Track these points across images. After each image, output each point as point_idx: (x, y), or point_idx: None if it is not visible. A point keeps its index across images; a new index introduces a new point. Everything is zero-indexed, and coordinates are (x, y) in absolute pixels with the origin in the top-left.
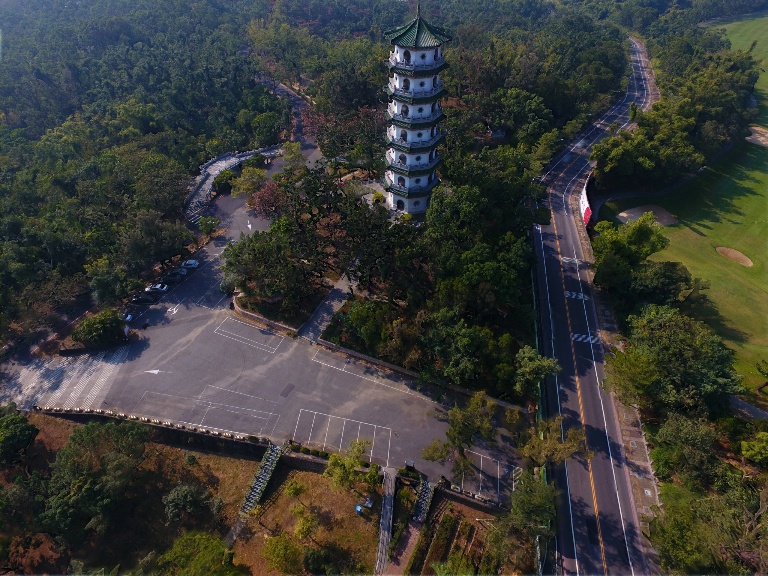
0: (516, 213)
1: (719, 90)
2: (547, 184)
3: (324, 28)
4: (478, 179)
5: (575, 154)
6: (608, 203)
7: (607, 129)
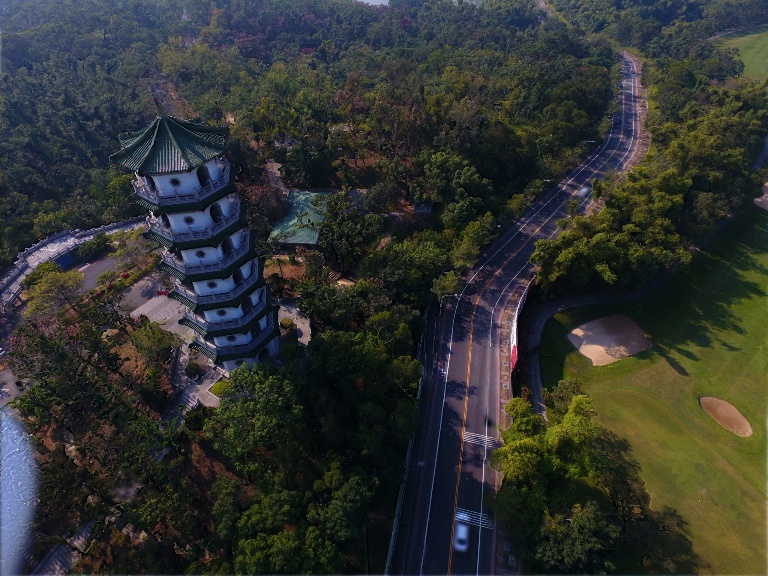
0: (360, 415)
1: (721, 144)
2: (475, 289)
3: (272, 42)
4: (344, 317)
5: (524, 236)
6: (558, 315)
7: (574, 193)
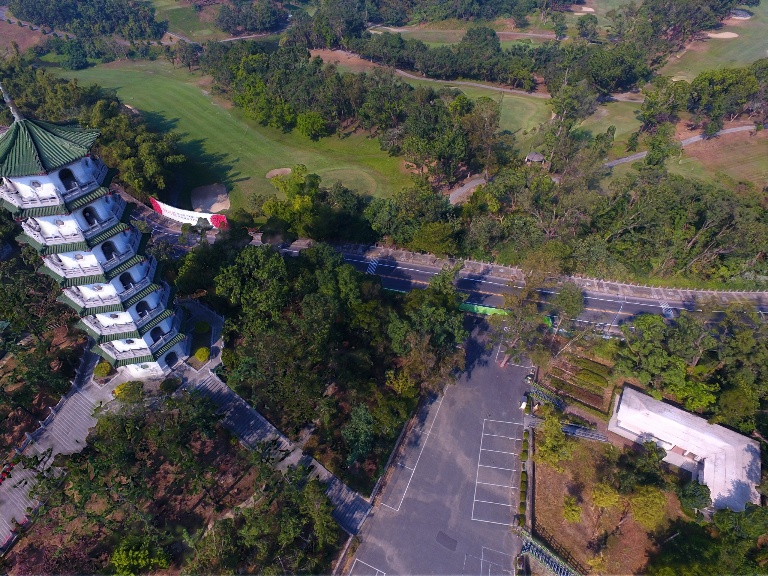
0: None
1: None
2: None
3: None
4: None
5: None
6: None
7: None
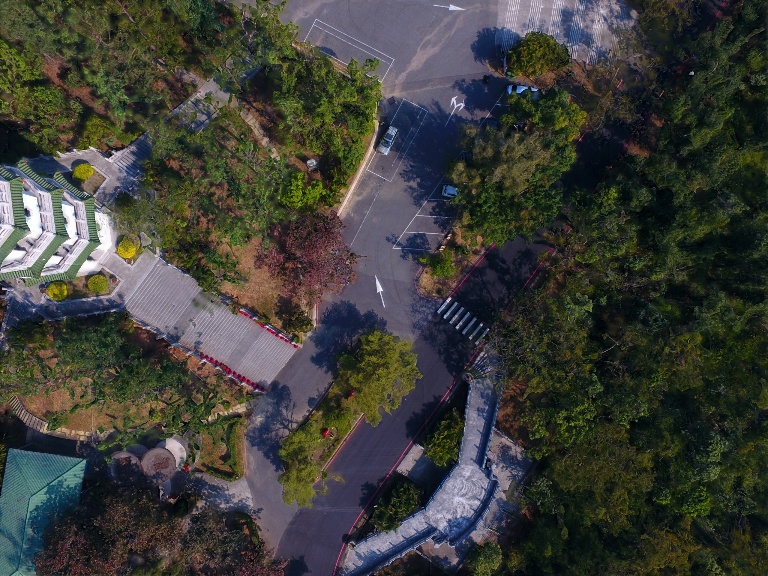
0: None
1: None
2: None
3: None
4: None
5: None
6: None
7: None
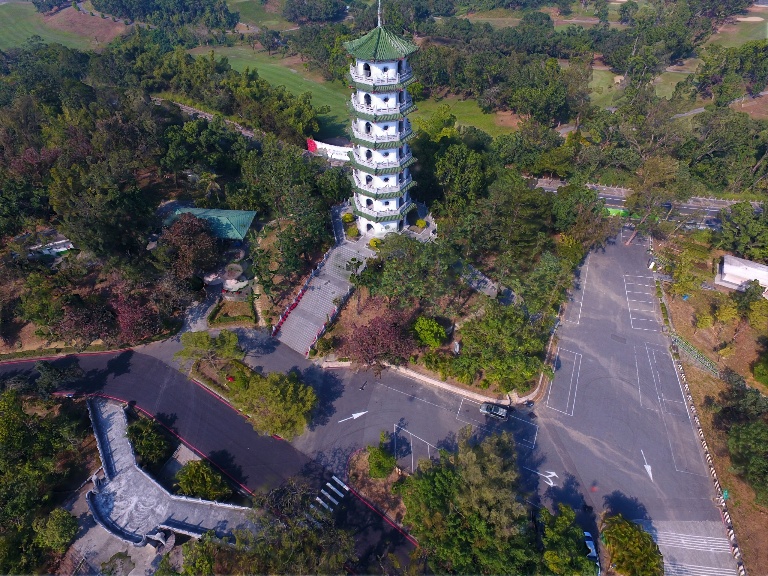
0: None
1: None
2: None
3: None
4: None
5: None
6: None
7: None
